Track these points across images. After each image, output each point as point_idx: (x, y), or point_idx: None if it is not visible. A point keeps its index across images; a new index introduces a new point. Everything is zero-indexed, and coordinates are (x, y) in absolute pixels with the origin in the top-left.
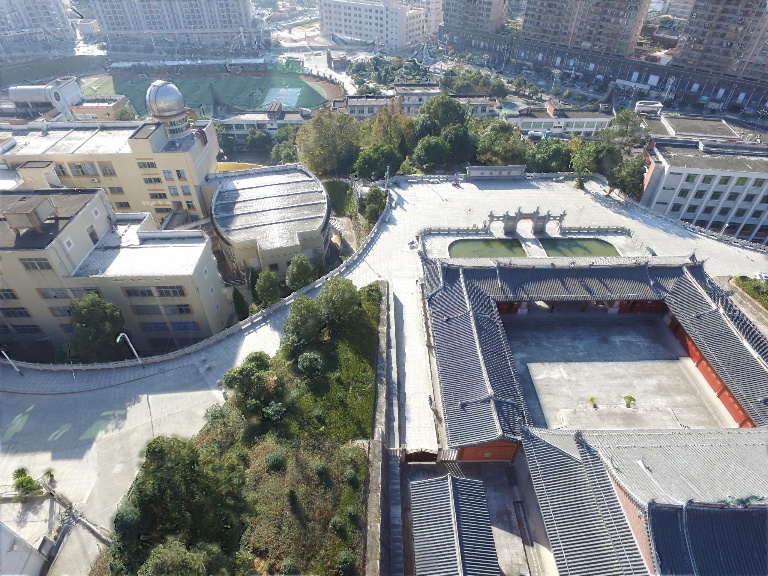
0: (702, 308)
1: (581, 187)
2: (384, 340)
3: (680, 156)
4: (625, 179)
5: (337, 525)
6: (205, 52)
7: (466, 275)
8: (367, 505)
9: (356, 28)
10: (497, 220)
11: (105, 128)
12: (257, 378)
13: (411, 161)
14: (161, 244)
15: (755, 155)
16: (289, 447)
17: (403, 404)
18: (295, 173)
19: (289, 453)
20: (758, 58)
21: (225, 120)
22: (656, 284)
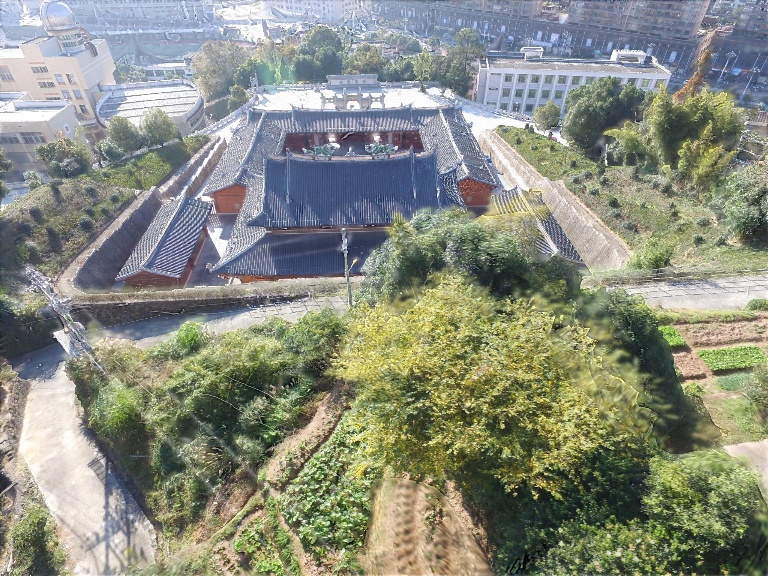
0: (439, 130)
1: (423, 91)
2: (194, 159)
3: (505, 63)
4: (448, 76)
5: (87, 208)
6: (147, 23)
7: (268, 117)
8: (122, 212)
9: (296, 3)
10: (329, 102)
11: (10, 47)
12: (58, 146)
13: (290, 80)
14: (32, 110)
15: (568, 62)
16: (72, 181)
17: (196, 194)
18: (181, 86)
19: (70, 183)
20: (636, 11)
21: (146, 67)
22: (416, 120)
